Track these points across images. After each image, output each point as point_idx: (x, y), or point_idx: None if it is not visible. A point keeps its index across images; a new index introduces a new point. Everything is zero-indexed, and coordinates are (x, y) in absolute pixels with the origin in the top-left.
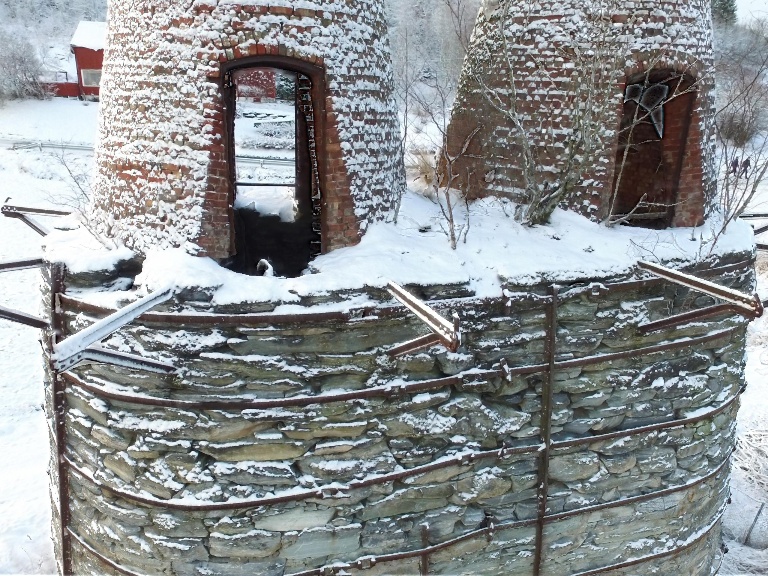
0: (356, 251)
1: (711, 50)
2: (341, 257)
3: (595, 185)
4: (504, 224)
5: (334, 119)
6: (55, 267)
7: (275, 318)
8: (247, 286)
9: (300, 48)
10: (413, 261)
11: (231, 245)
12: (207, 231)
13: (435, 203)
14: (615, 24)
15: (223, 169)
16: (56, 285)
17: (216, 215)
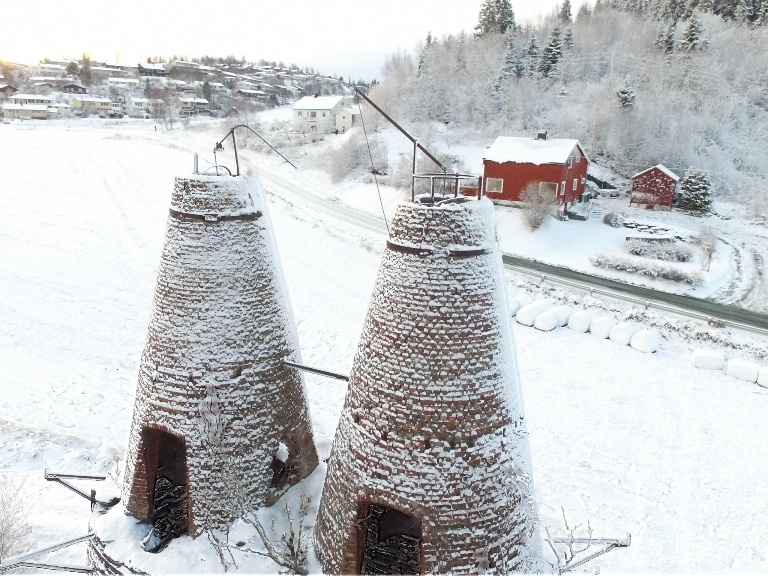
0: (185, 546)
1: (460, 496)
2: (178, 546)
3: (336, 567)
4: (278, 565)
5: (188, 469)
6: (93, 492)
7: (118, 572)
8: (120, 547)
9: (174, 430)
10: (198, 569)
11: (150, 512)
12: (133, 504)
13: (306, 514)
14: (358, 460)
15: (144, 476)
16: (93, 499)
17: (139, 497)
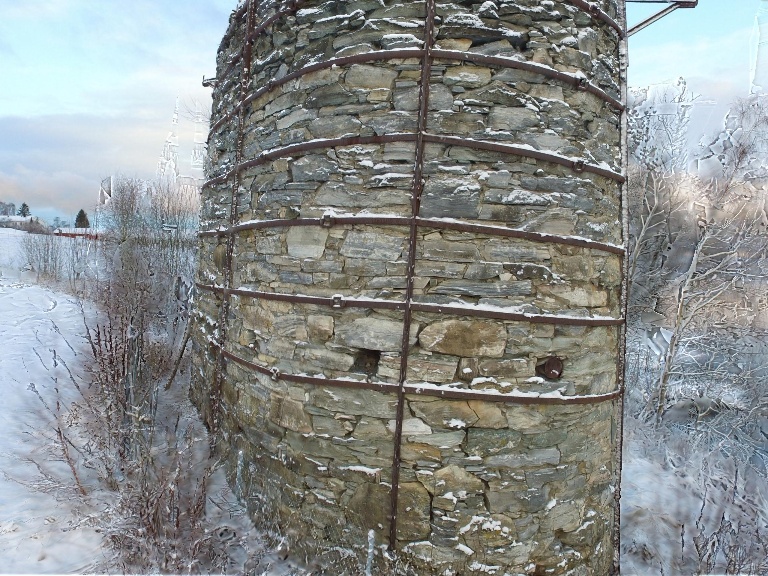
0: None
1: None
2: None
3: None
4: None
5: None
6: None
7: None
8: None
9: None
10: None
11: None
12: None
13: None
14: None
15: None
16: None
17: None
